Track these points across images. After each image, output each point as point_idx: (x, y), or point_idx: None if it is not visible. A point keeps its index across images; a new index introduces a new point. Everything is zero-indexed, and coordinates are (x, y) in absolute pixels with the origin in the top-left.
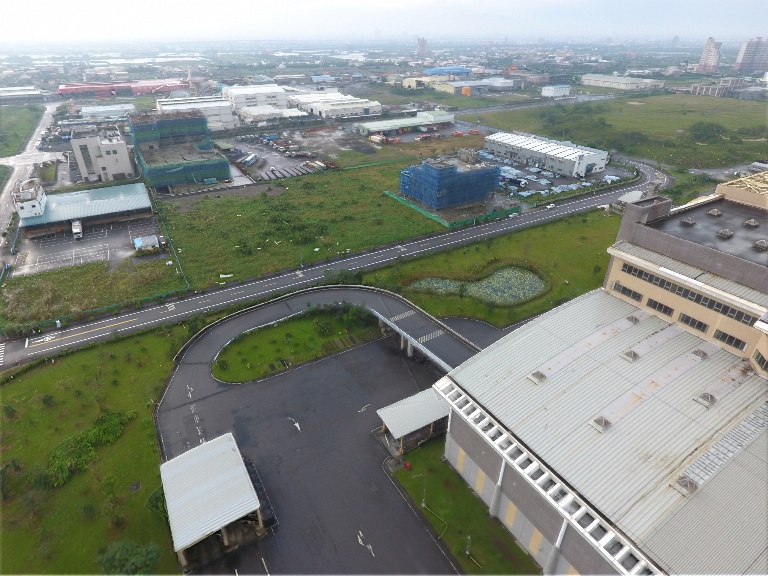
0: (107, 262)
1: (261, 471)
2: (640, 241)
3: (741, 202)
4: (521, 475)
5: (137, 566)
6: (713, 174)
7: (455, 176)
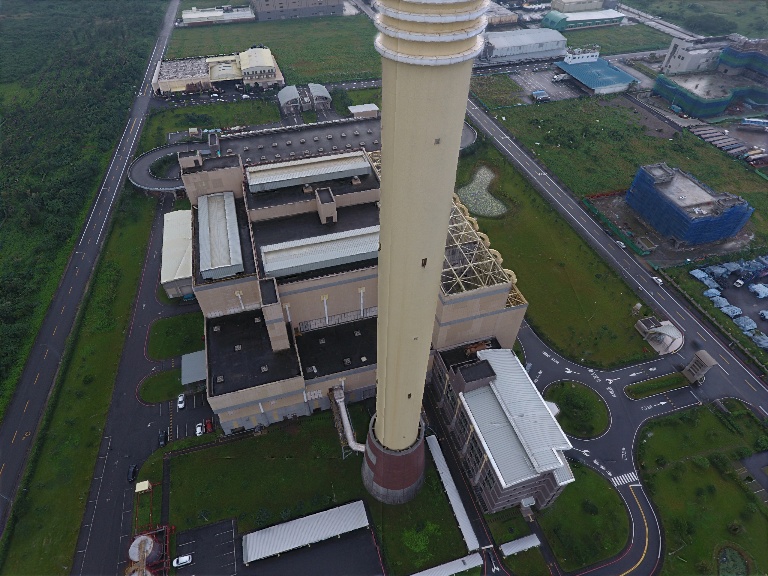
0: (522, 91)
1: None
2: None
3: None
4: None
5: (344, 100)
6: None
7: None
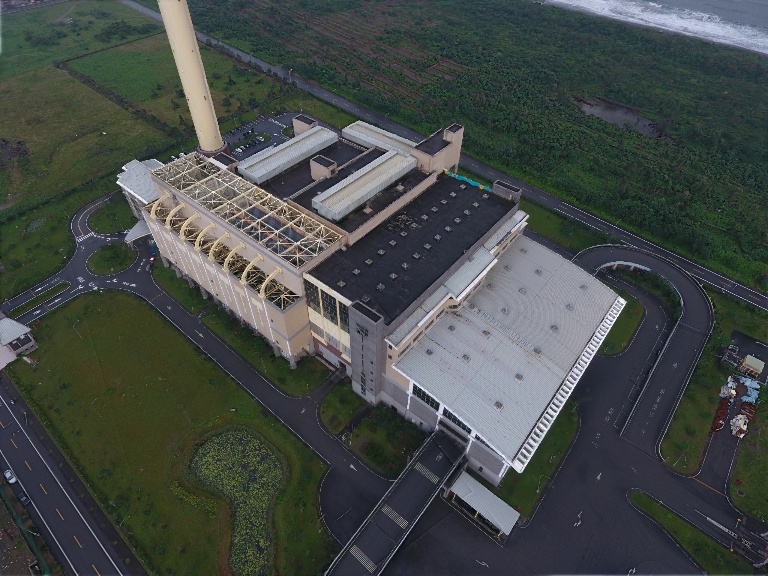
0: None
1: None
2: None
3: (314, 266)
4: None
5: None
6: None
7: None
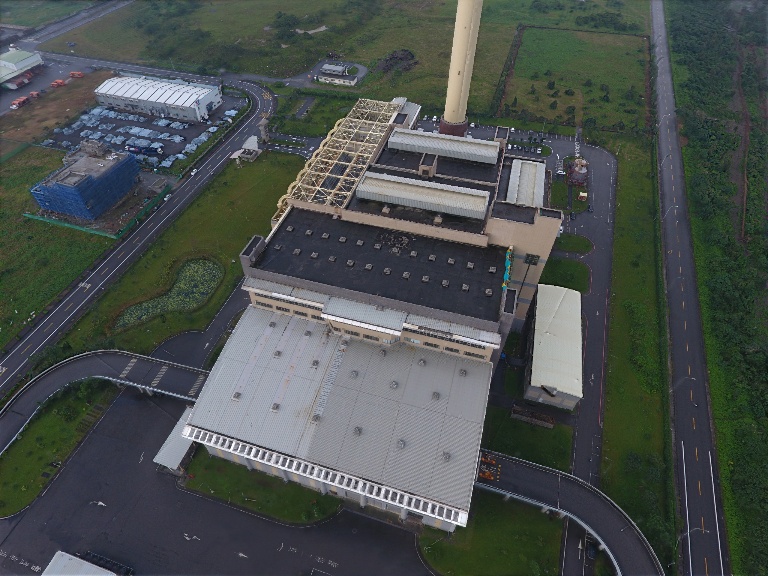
0: None
1: (97, 551)
2: (257, 276)
3: (302, 208)
4: (250, 458)
5: None
6: (301, 82)
7: (94, 183)
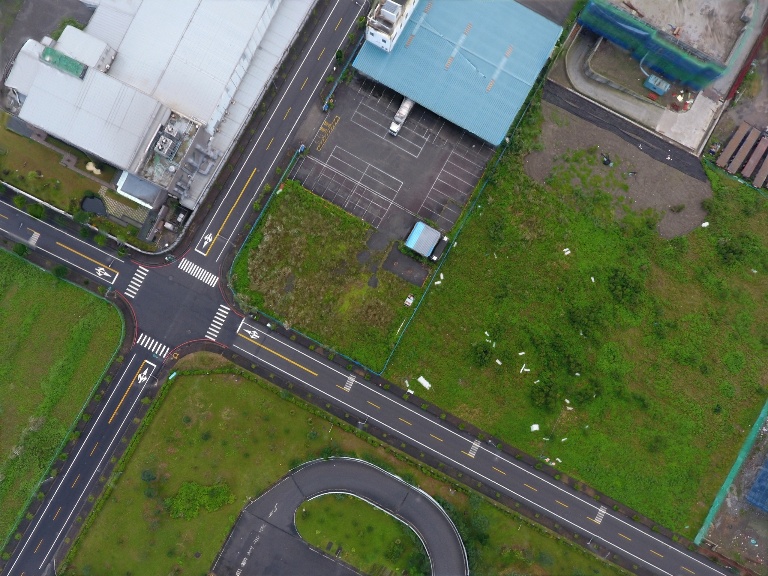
0: (371, 234)
1: None
2: None
3: None
4: None
5: None
6: None
7: None
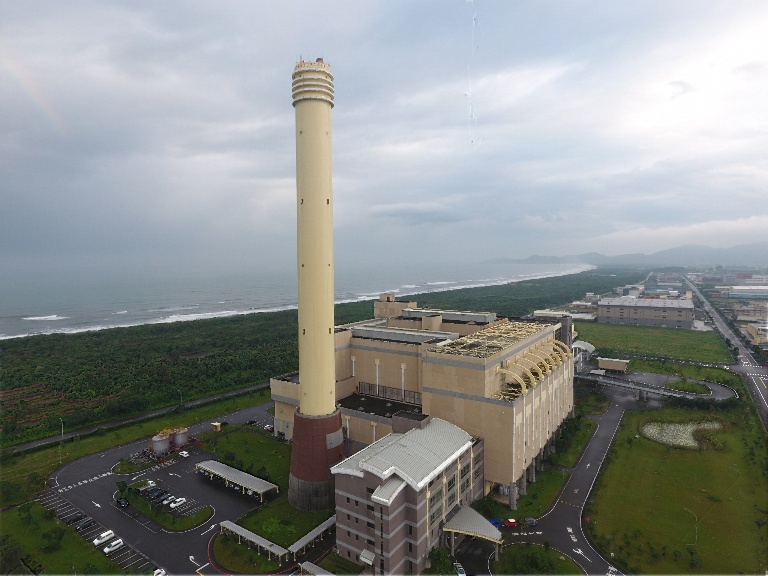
0: None
1: None
2: None
3: None
4: None
5: None
6: None
7: None
